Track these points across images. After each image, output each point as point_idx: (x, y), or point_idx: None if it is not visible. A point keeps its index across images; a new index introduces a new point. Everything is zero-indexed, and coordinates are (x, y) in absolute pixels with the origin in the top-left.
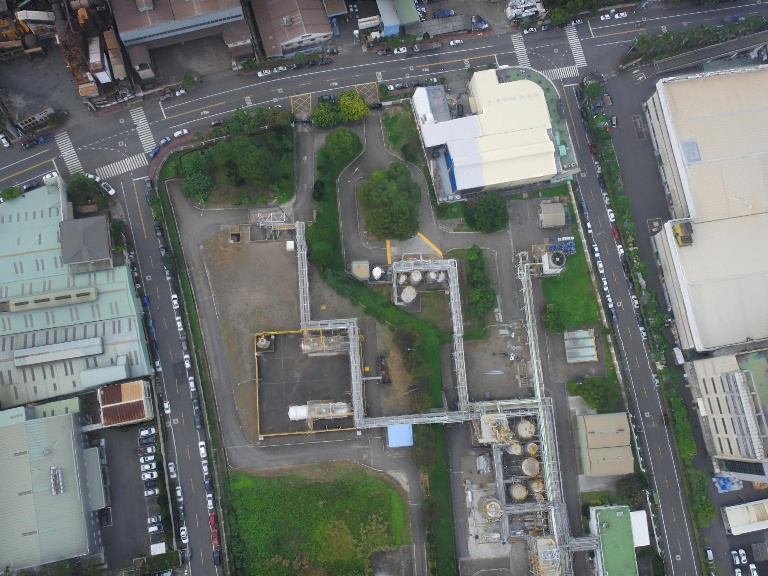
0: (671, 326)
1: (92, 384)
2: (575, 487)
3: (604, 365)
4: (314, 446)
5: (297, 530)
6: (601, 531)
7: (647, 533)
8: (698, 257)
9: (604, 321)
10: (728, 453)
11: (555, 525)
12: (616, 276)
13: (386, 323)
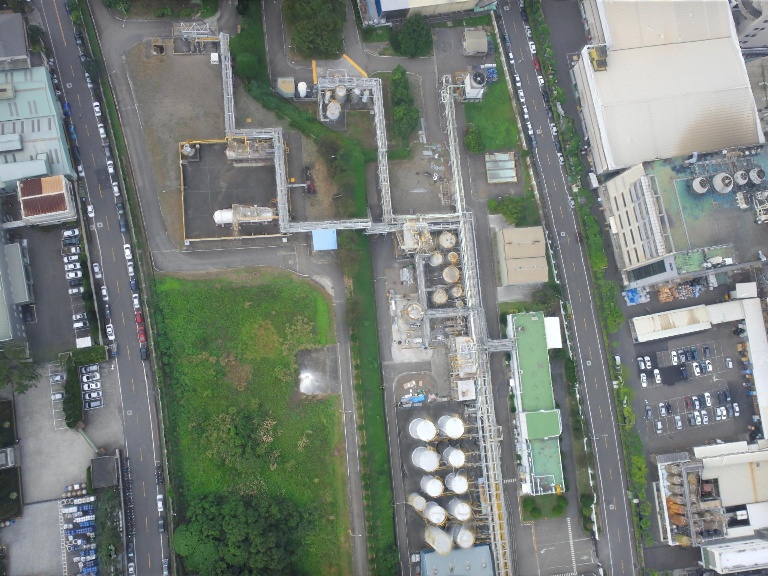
0: (587, 154)
1: (11, 178)
2: (494, 298)
3: (523, 186)
4: (240, 252)
5: (224, 329)
6: (517, 334)
7: (560, 337)
8: (612, 81)
9: (524, 145)
10: (635, 262)
11: (473, 328)
12: (536, 105)
13: (311, 137)
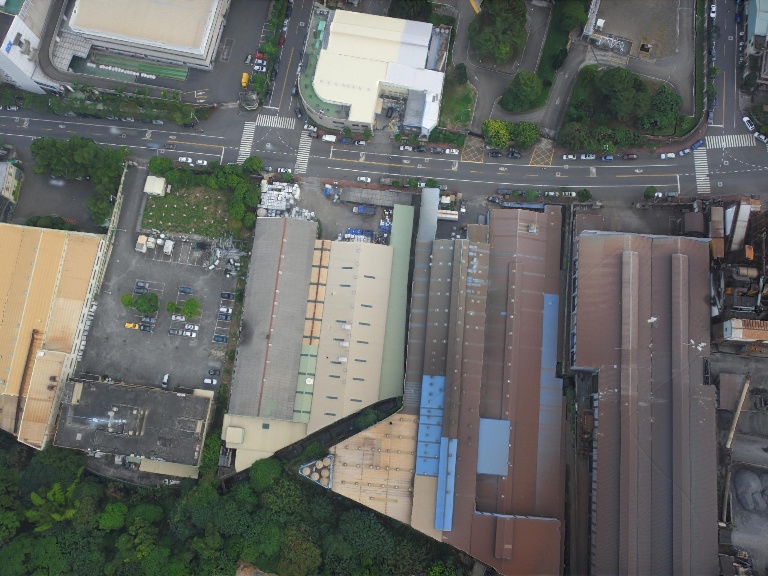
0: None
1: None
2: None
3: None
4: None
5: None
6: None
7: None
8: None
9: None
10: None
11: None
12: None
13: None
